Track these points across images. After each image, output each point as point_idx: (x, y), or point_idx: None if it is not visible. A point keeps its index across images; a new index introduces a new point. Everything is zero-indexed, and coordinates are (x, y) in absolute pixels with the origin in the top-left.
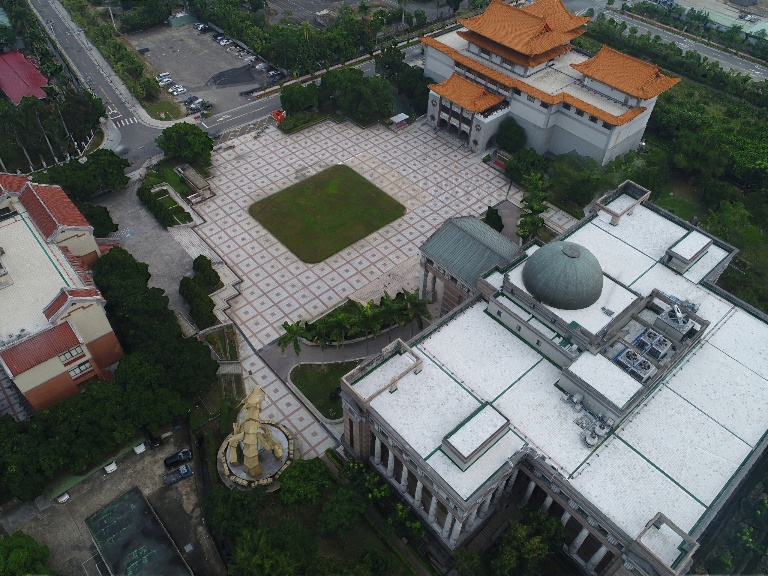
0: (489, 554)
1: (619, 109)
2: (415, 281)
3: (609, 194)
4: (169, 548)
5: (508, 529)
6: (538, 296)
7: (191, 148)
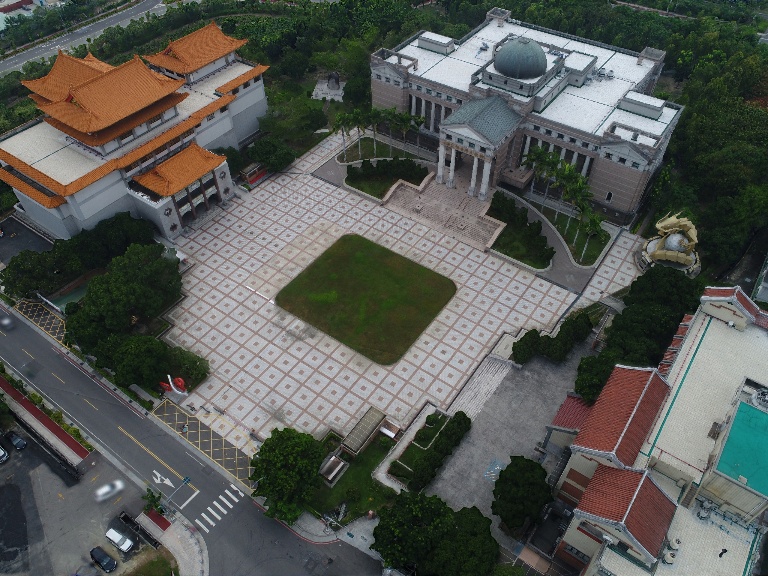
0: None
1: (238, 67)
2: (452, 210)
3: None
4: None
5: None
6: None
7: (310, 447)
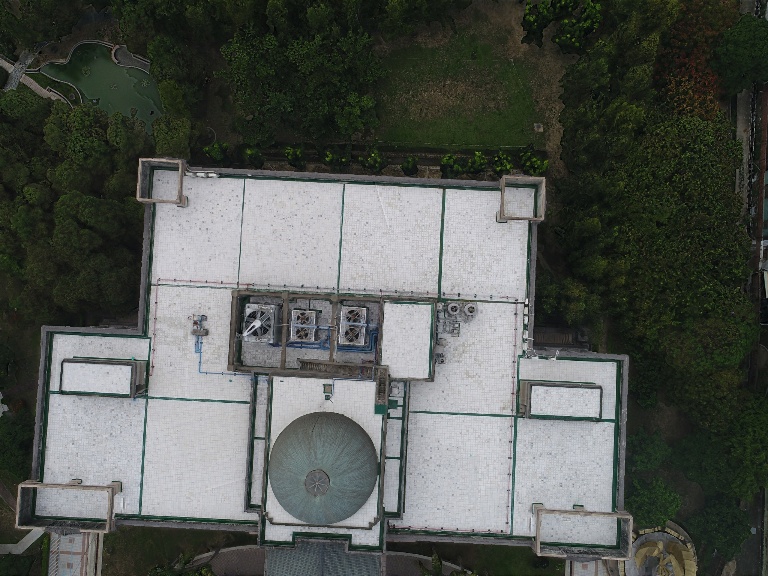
0: None
1: None
2: None
3: (71, 529)
4: None
5: None
6: None
7: None
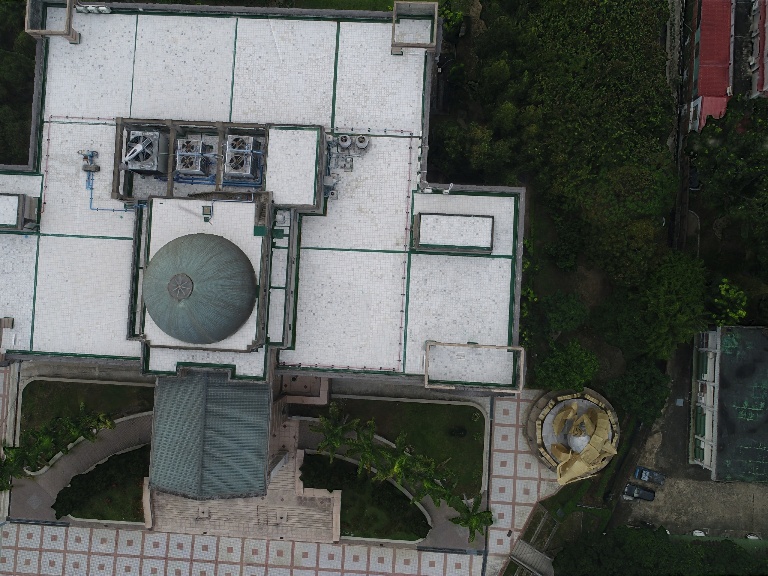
0: (485, 180)
1: None
2: None
3: None
4: (722, 399)
5: (479, 165)
6: (255, 292)
7: None
